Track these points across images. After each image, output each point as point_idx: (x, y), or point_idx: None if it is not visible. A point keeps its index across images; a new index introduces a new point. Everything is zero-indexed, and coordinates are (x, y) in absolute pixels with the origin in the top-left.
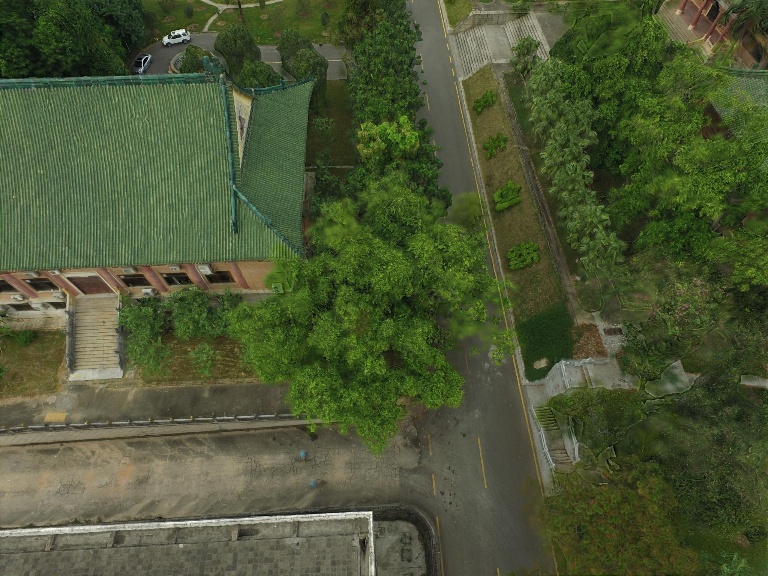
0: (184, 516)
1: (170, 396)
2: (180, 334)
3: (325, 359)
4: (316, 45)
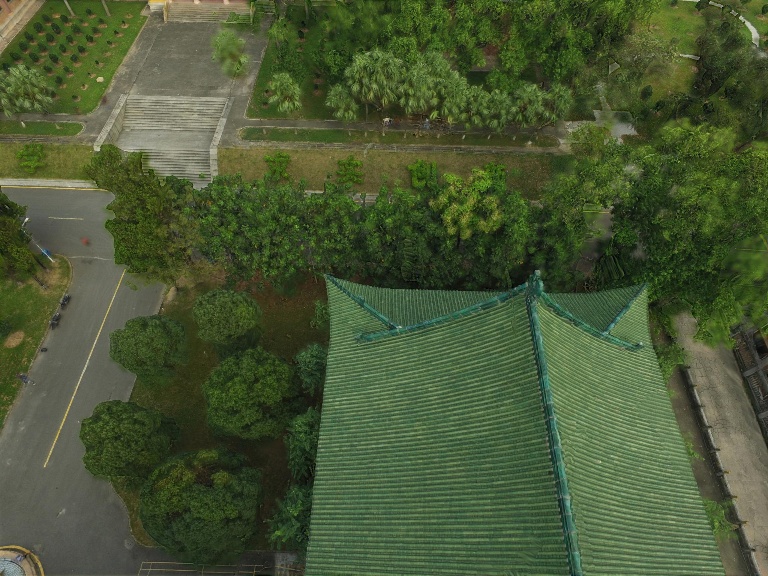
0: None
1: None
2: None
3: None
4: (39, 358)
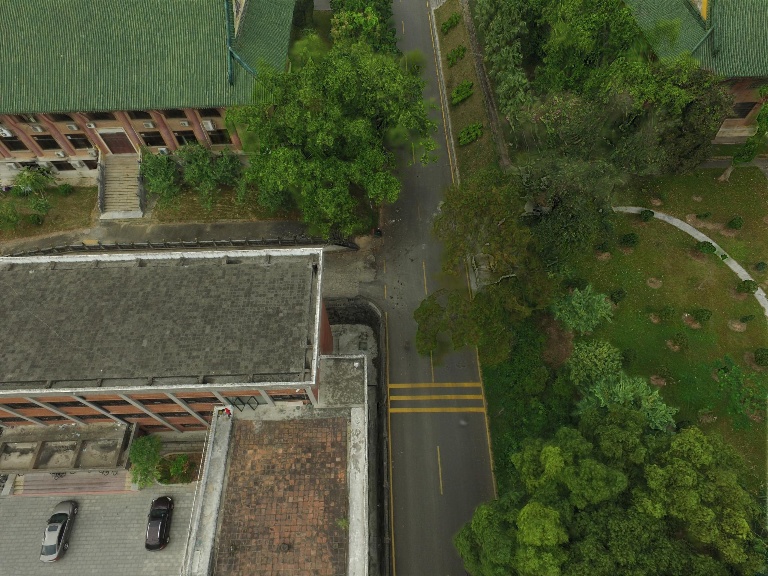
0: None
1: (180, 230)
2: (188, 179)
3: (291, 144)
4: None
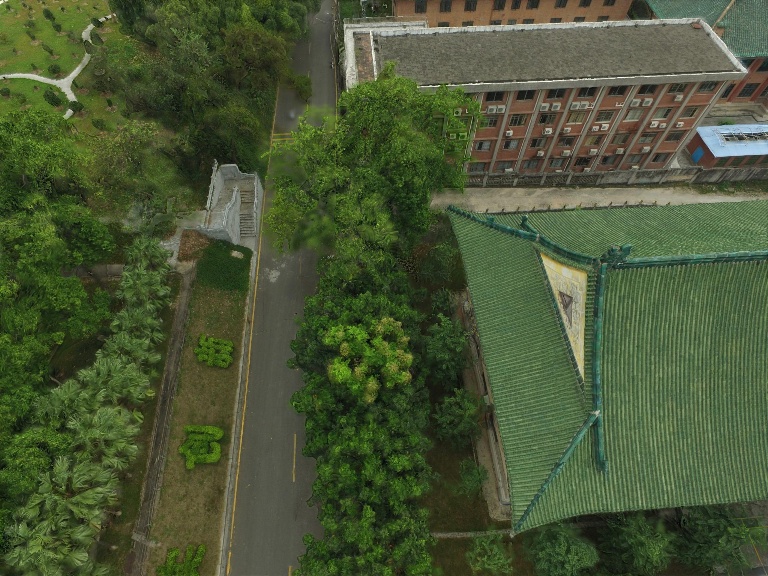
0: (505, 188)
1: None
2: None
3: None
4: None
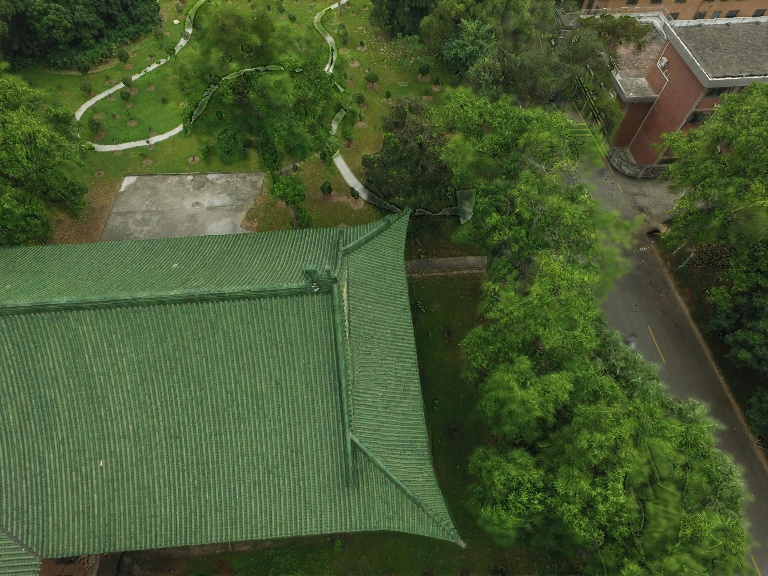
0: None
1: None
2: None
3: None
4: None
